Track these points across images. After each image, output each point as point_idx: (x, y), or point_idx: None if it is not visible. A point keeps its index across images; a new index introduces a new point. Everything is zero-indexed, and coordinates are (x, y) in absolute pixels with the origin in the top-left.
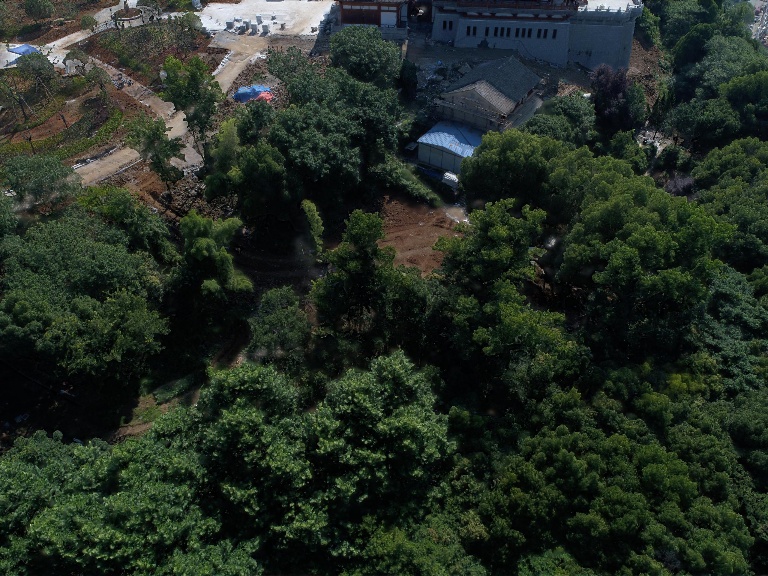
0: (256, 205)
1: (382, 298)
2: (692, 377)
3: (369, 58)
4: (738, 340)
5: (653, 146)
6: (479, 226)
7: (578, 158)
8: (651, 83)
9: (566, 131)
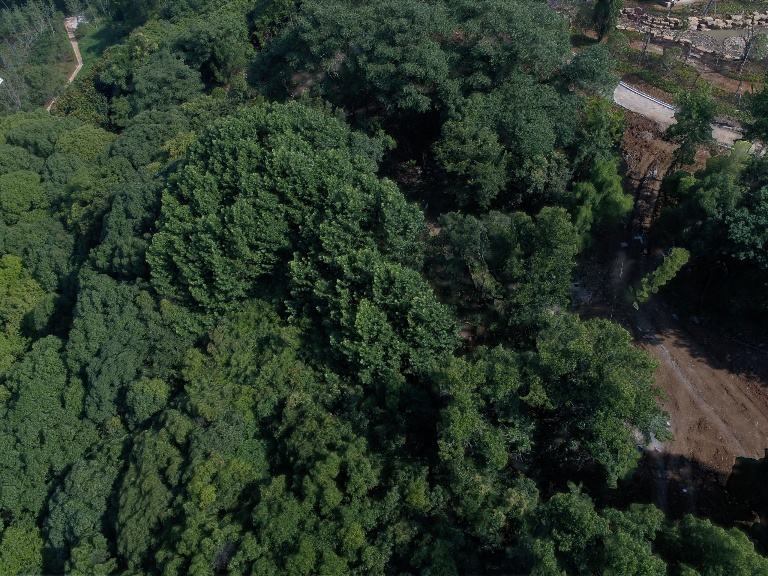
0: (668, 219)
1: (510, 293)
2: None
3: None
4: None
5: None
6: None
7: None
8: None
9: None
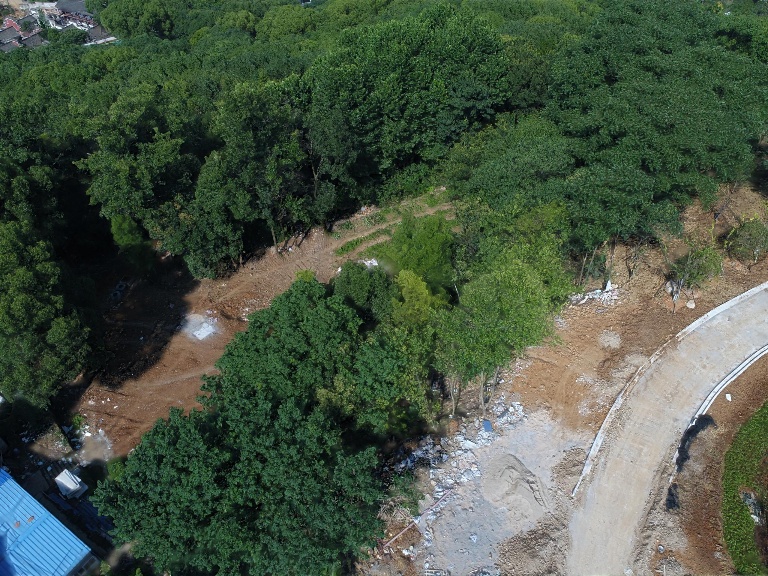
0: None
1: None
2: None
3: None
4: None
5: None
6: None
7: None
8: None
9: None
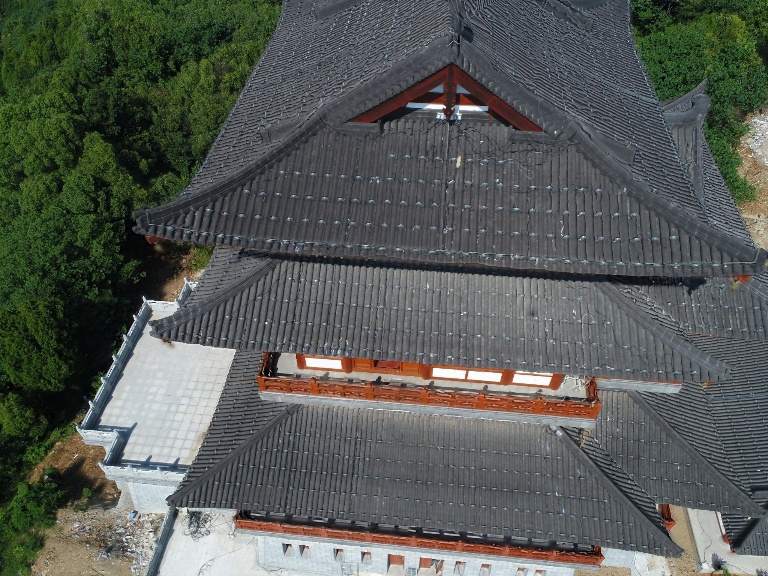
0: None
1: None
2: None
3: None
4: None
5: None
6: None
7: None
8: None
9: None
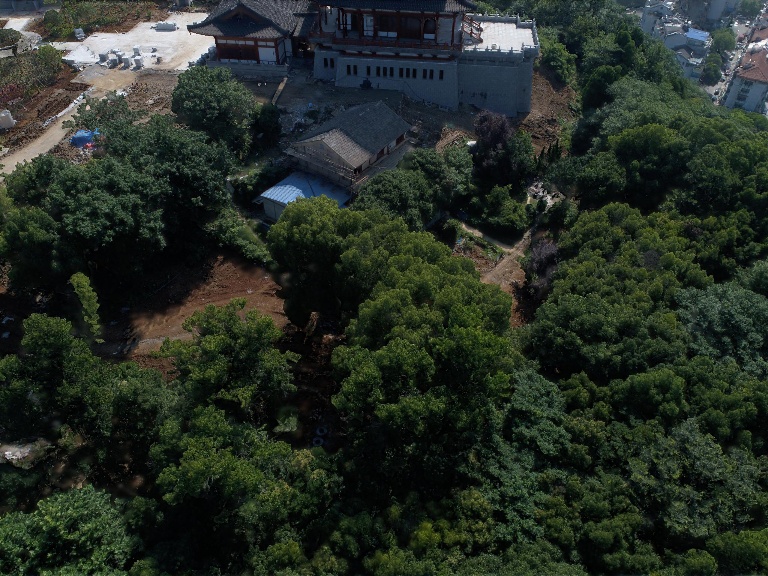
0: (24, 277)
1: (82, 415)
2: (452, 524)
3: (207, 103)
4: (526, 471)
5: (542, 201)
6: (199, 331)
7: (390, 232)
8: (553, 128)
9: (420, 189)
